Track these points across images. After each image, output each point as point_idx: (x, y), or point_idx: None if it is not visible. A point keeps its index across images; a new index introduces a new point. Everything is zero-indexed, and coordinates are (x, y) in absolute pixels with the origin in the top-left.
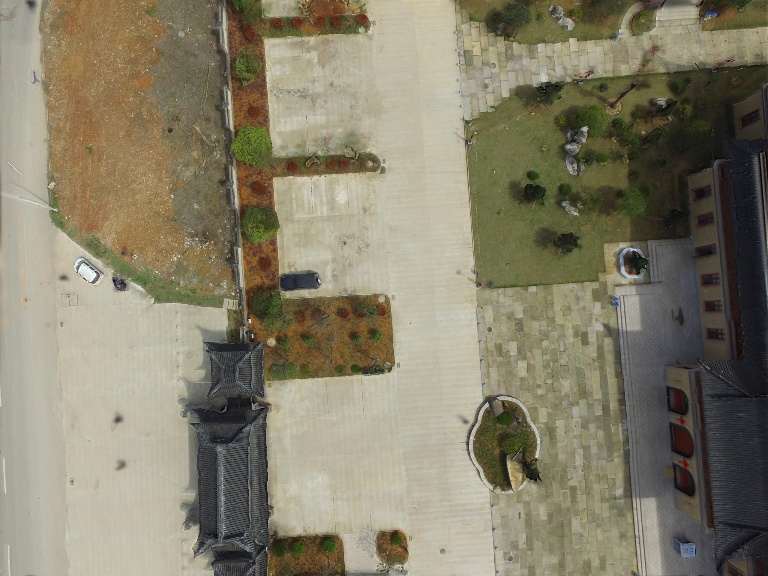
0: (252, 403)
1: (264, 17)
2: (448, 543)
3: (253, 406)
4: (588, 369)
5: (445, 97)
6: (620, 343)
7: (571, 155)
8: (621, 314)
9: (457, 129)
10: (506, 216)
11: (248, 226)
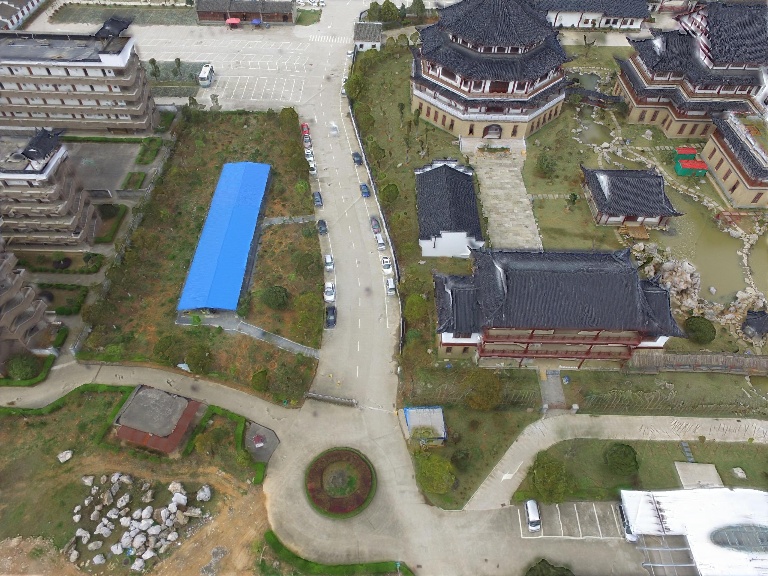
0: (698, 5)
1: None
2: None
3: (697, 5)
4: None
5: None
6: None
7: None
8: None
9: None
10: None
11: (756, 4)
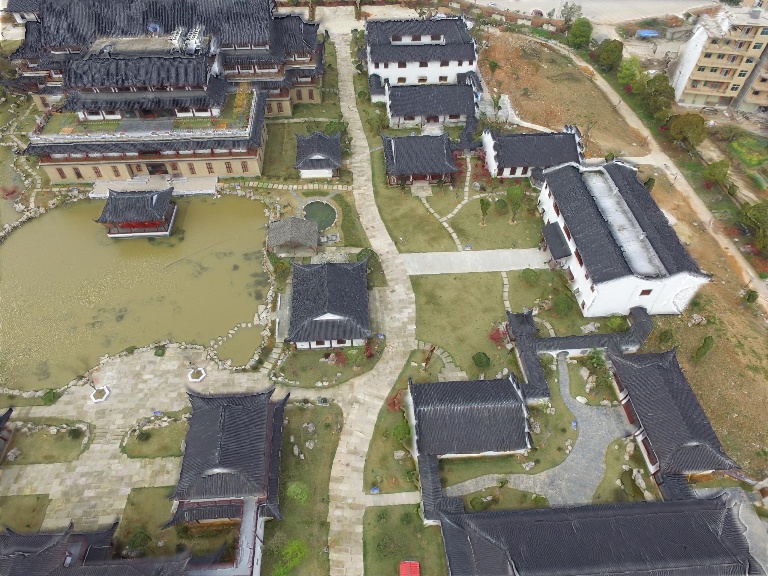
0: None
1: (361, 6)
2: None
3: None
4: None
5: (332, 31)
6: None
7: None
8: None
9: None
10: None
11: None
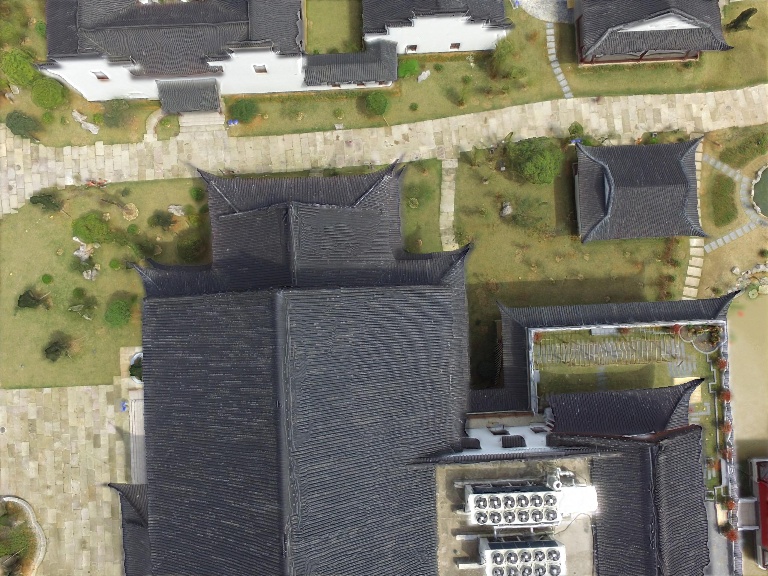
0: None
1: None
2: None
3: None
4: (99, 472)
5: None
6: (130, 447)
7: (82, 260)
8: (132, 418)
9: None
10: (22, 318)
11: None
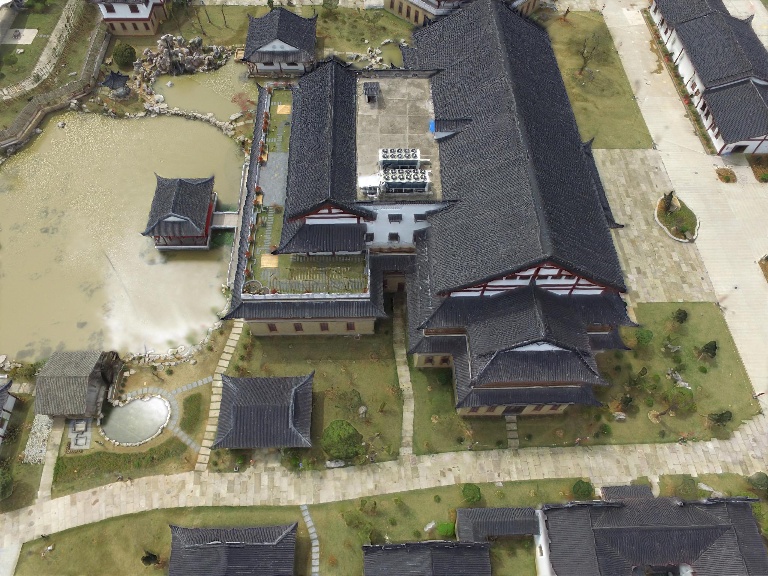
0: None
1: None
2: (694, 176)
3: None
4: (633, 254)
5: None
6: None
7: None
8: None
9: (766, 408)
10: None
11: None
